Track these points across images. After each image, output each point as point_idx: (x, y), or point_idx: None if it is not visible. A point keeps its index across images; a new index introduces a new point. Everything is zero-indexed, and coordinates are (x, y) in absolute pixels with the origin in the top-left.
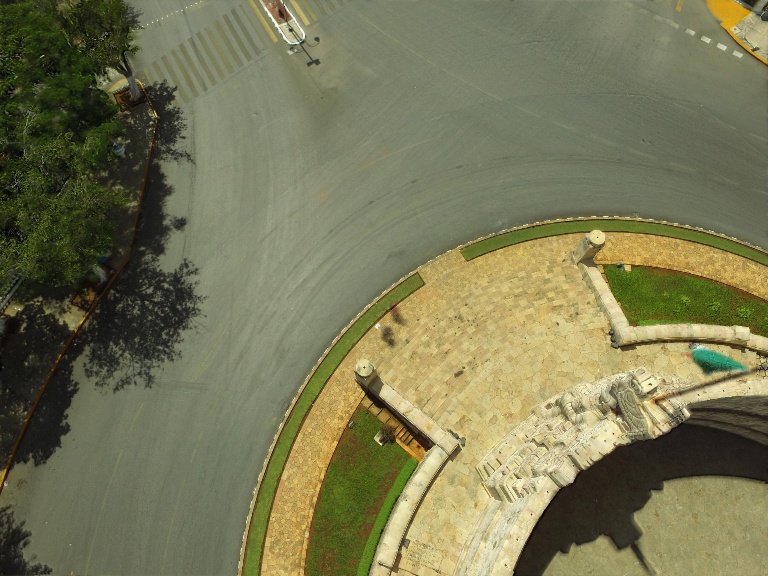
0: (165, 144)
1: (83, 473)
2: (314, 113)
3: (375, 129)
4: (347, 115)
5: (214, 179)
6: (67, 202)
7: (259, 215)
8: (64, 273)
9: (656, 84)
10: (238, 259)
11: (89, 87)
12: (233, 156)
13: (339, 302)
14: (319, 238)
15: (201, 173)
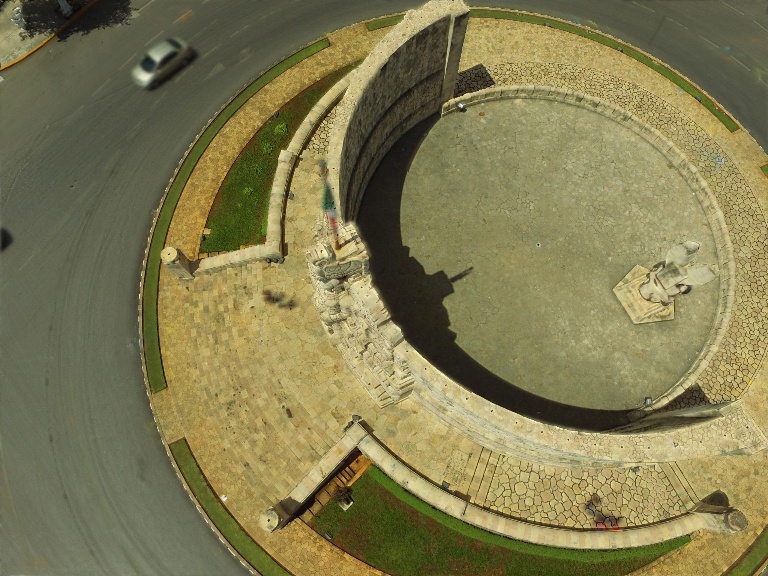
0: None
1: None
2: None
3: None
4: None
5: None
6: None
7: None
8: None
9: (7, 160)
10: None
11: None
12: None
13: (187, 545)
14: (97, 569)
15: None
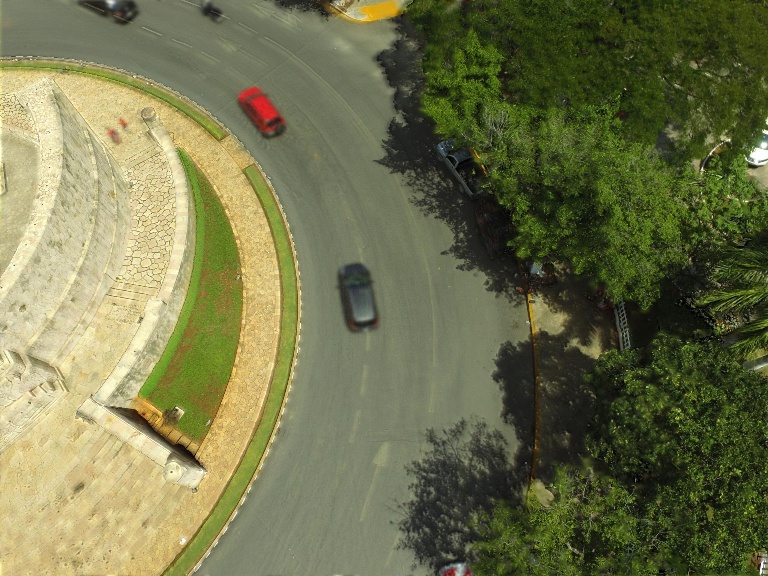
0: None
1: (462, 341)
2: None
3: None
4: None
5: None
6: None
7: None
8: None
9: None
10: None
11: None
12: None
13: (233, 569)
14: None
15: None
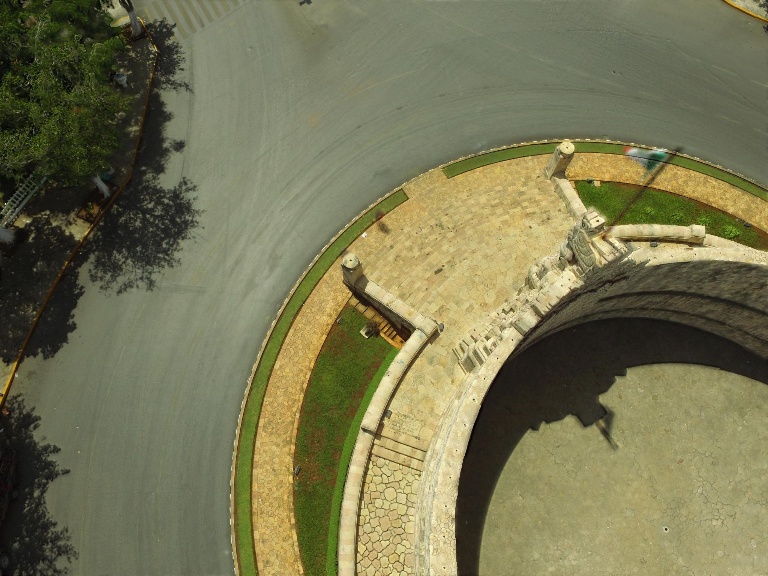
0: (165, 75)
1: (89, 365)
2: (306, 47)
3: (363, 62)
4: (337, 49)
5: (211, 106)
6: (76, 98)
7: (254, 138)
8: (73, 166)
9: (627, 22)
10: (234, 177)
11: (94, 9)
12: (229, 86)
13: (328, 215)
14: (310, 158)
15: (199, 101)
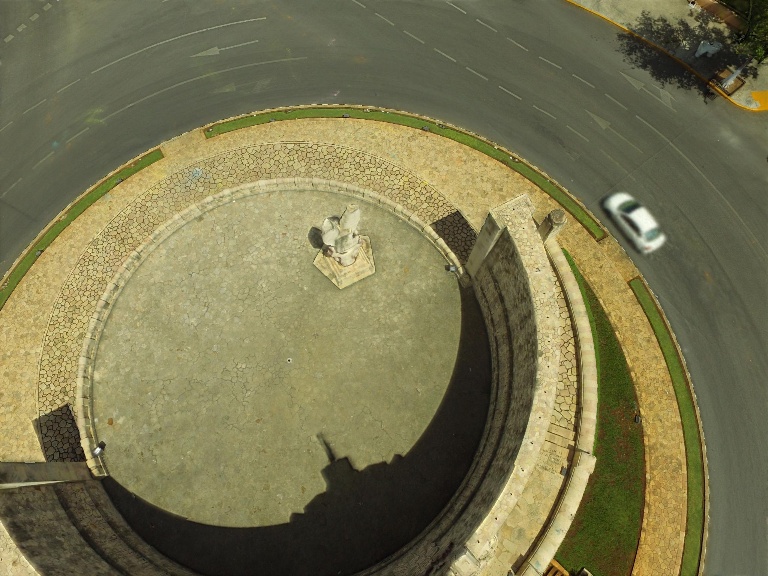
0: None
1: None
2: None
3: None
4: None
5: None
6: None
7: None
8: None
9: None
10: None
11: None
12: None
13: None
14: None
15: None
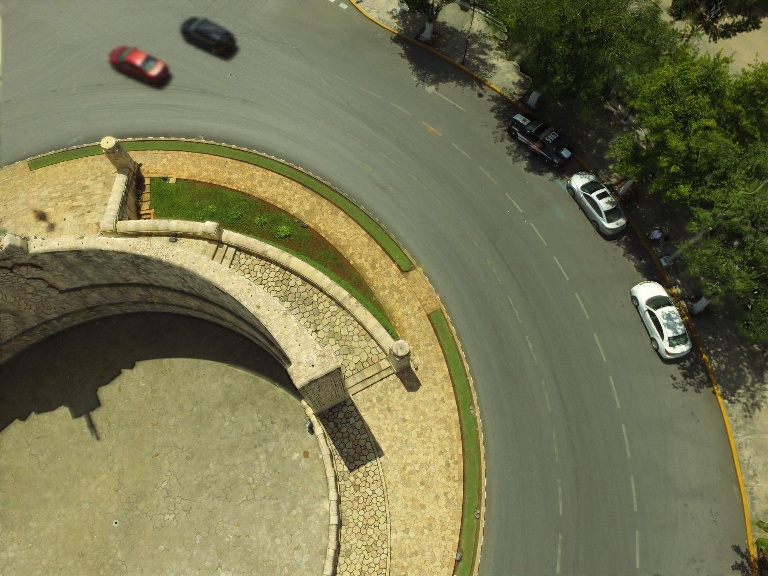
0: None
1: None
2: None
3: None
4: None
5: None
6: None
7: None
8: None
9: (259, 27)
10: None
11: None
12: None
13: None
14: None
15: None
